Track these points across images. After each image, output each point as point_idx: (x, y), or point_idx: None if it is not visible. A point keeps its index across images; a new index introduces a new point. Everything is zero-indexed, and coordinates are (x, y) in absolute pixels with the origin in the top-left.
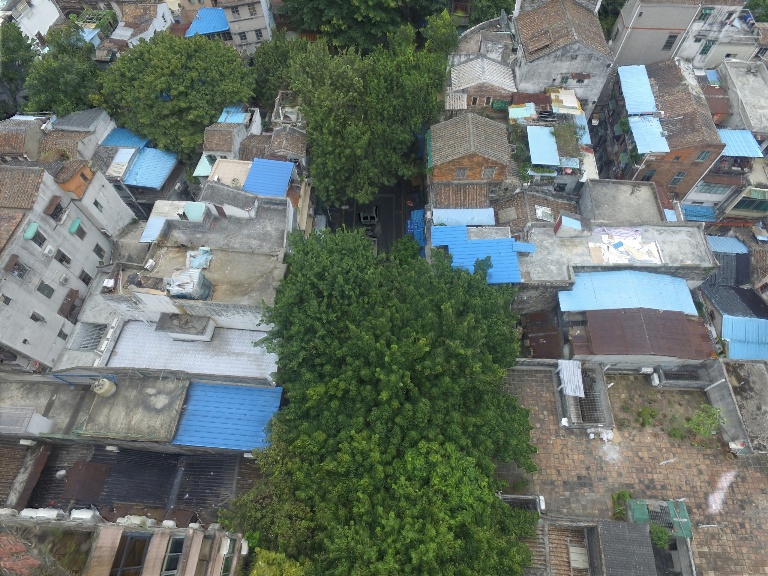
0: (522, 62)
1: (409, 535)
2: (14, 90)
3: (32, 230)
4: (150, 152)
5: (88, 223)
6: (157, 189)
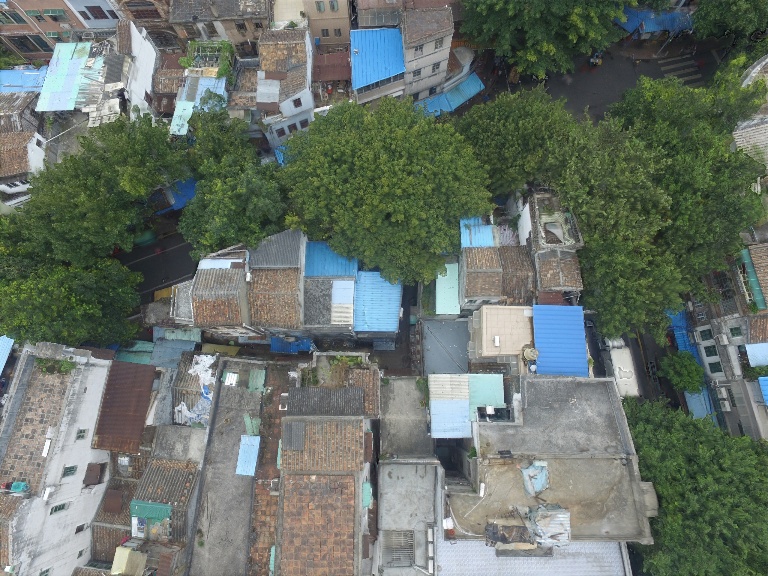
0: None
1: None
2: None
3: (367, 495)
4: (366, 278)
5: None
6: None
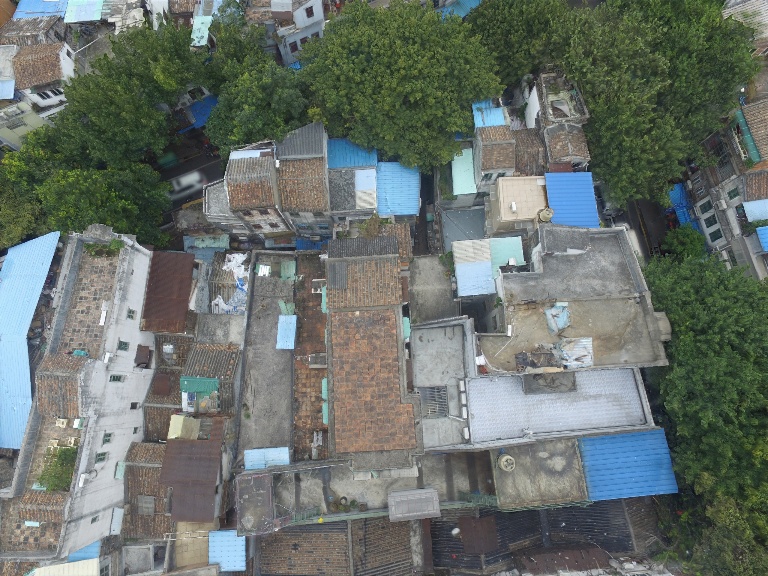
0: None
1: None
2: None
3: (407, 327)
4: (386, 168)
5: None
6: None
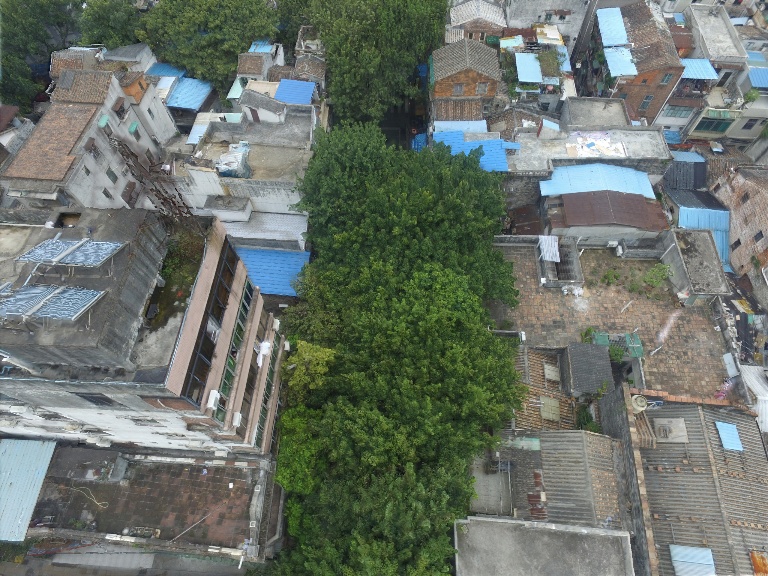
0: (512, 0)
1: (417, 308)
2: (64, 32)
3: (104, 120)
4: (188, 81)
5: (142, 128)
6: (195, 111)
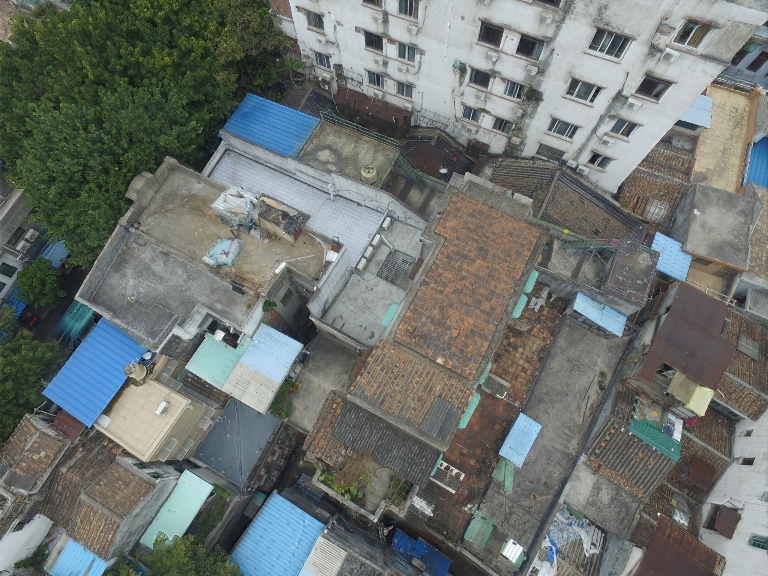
0: None
1: None
2: None
3: (390, 314)
4: None
5: None
6: None
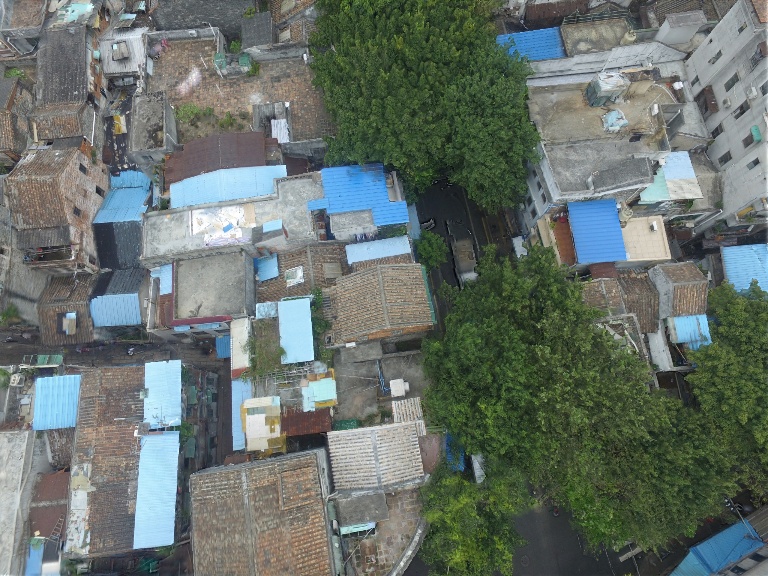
0: None
1: None
2: None
3: None
4: None
5: None
6: None
